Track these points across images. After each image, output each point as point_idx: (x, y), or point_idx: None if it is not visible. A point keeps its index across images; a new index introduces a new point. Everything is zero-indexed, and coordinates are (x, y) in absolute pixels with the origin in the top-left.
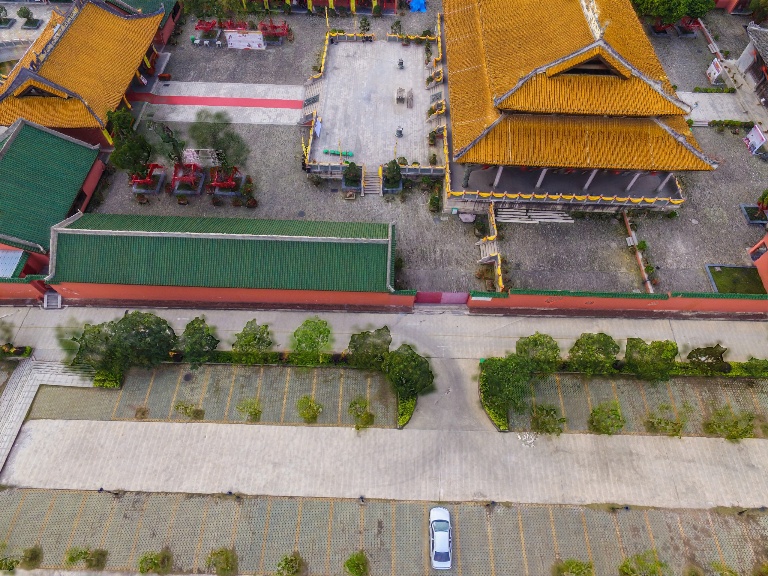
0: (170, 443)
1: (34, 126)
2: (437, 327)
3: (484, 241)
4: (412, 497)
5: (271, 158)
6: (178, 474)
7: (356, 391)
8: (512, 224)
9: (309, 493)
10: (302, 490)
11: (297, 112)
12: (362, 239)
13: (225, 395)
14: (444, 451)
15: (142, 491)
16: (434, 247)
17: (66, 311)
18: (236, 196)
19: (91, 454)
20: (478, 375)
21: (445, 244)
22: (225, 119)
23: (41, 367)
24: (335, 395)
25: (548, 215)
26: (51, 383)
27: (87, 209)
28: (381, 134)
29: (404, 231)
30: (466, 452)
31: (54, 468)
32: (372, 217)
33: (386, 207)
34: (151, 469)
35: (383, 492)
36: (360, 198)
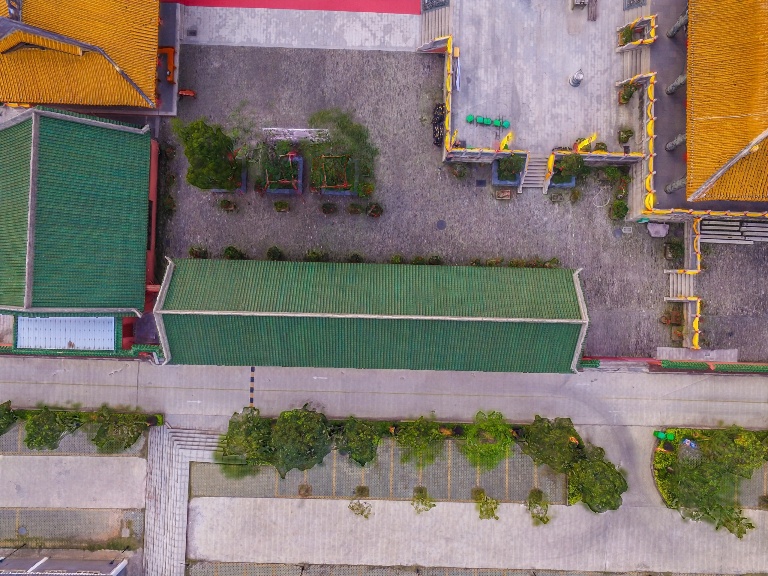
0: (341, 520)
1: (54, 116)
2: (610, 388)
3: (678, 272)
4: (579, 568)
5: (387, 122)
6: (356, 549)
7: (523, 466)
8: (717, 244)
9: (483, 565)
10: (476, 562)
11: (414, 22)
12: (552, 321)
13: (386, 471)
14: (612, 526)
15: (325, 564)
16: (612, 276)
17: (182, 367)
18: (351, 196)
19: (266, 531)
20: (652, 446)
21: (626, 271)
22: (307, 40)
23: (182, 439)
24: (501, 470)
25: (767, 231)
26: (201, 460)
27: (158, 221)
28: (548, 80)
29: (575, 251)
30: (633, 528)
31: (235, 544)
32: (533, 229)
33: (551, 212)
34: (329, 544)
35: (552, 564)
36: (516, 196)
